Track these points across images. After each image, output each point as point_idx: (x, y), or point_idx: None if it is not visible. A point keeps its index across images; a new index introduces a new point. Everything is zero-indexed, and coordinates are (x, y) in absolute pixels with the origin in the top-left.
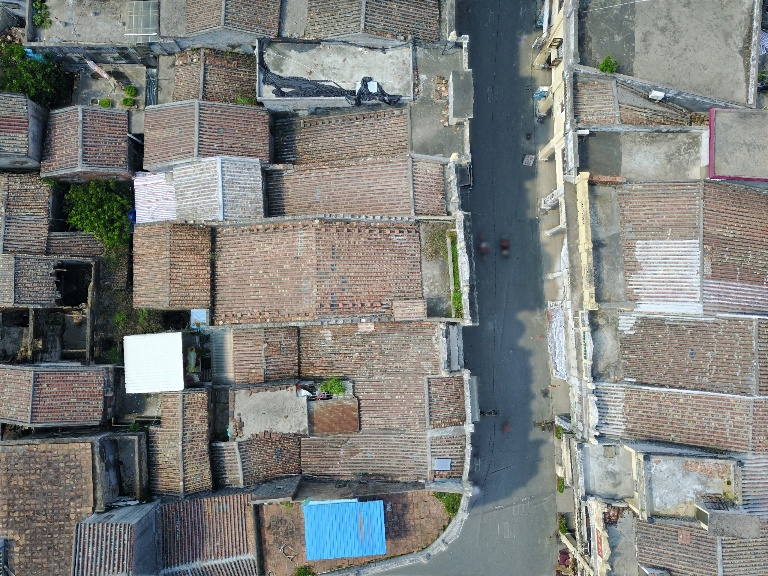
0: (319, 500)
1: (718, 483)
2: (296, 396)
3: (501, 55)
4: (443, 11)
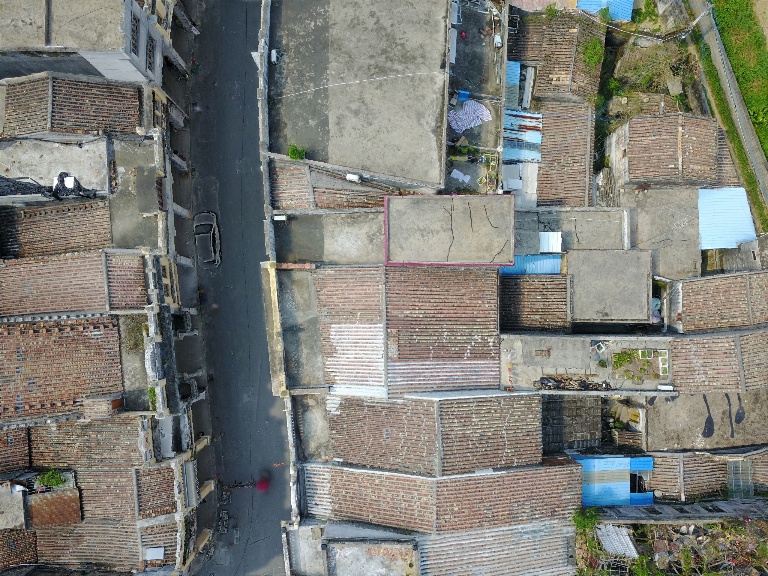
0: None
1: (401, 566)
2: (11, 491)
3: (248, 127)
4: None
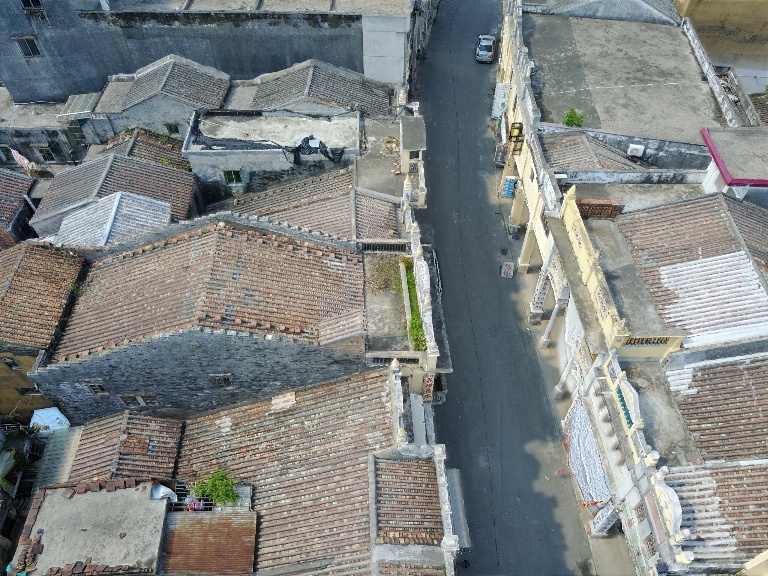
0: None
1: None
2: (149, 498)
3: (464, 188)
4: (394, 103)
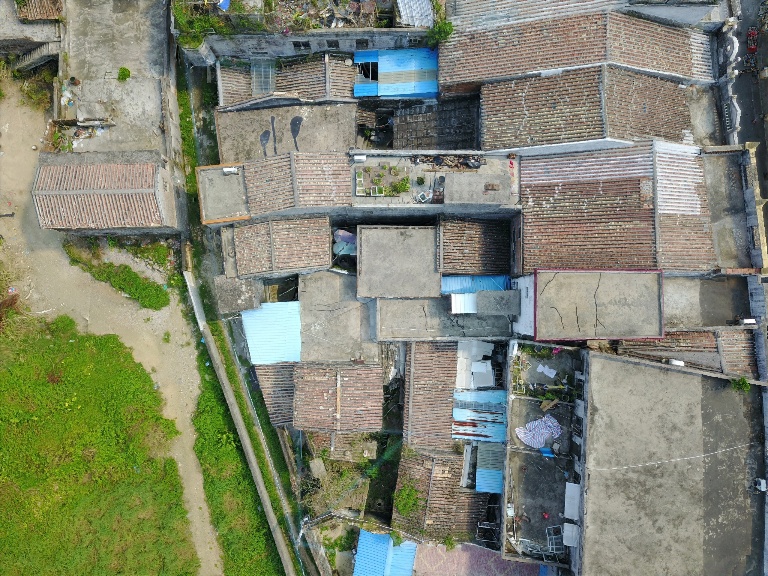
0: None
1: None
2: None
3: None
4: None
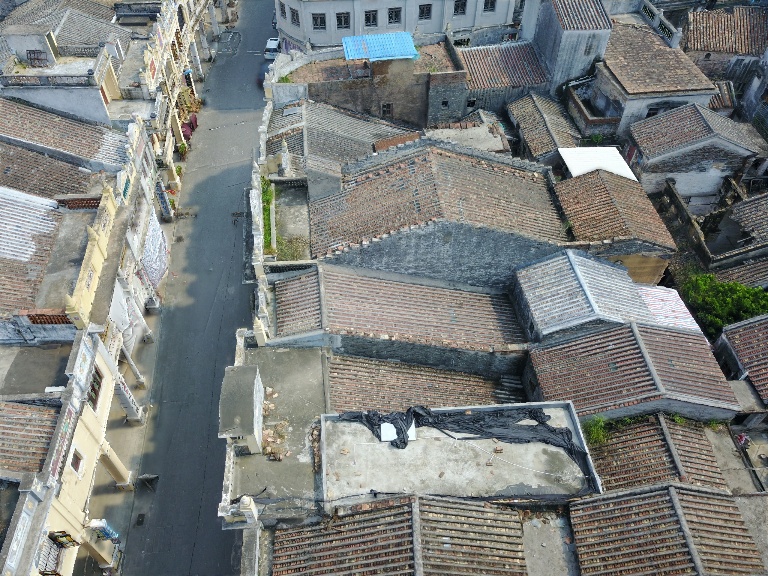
0: (405, 68)
1: None
2: None
3: None
4: None
